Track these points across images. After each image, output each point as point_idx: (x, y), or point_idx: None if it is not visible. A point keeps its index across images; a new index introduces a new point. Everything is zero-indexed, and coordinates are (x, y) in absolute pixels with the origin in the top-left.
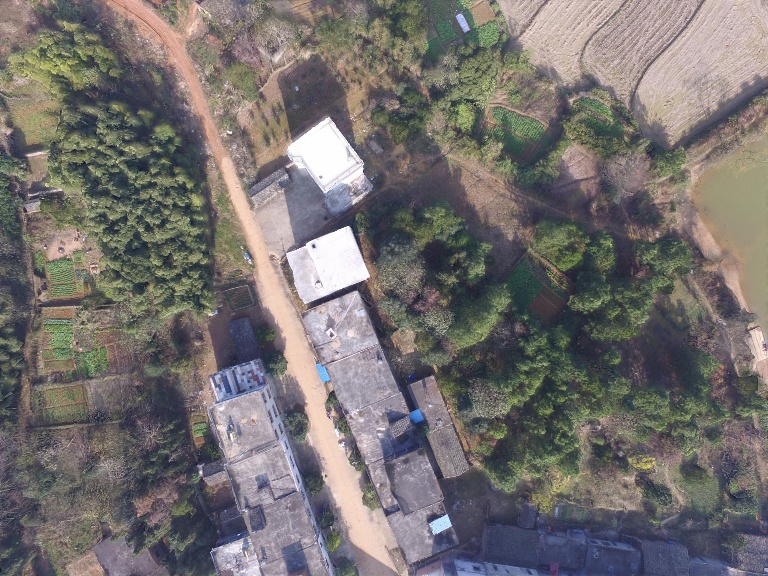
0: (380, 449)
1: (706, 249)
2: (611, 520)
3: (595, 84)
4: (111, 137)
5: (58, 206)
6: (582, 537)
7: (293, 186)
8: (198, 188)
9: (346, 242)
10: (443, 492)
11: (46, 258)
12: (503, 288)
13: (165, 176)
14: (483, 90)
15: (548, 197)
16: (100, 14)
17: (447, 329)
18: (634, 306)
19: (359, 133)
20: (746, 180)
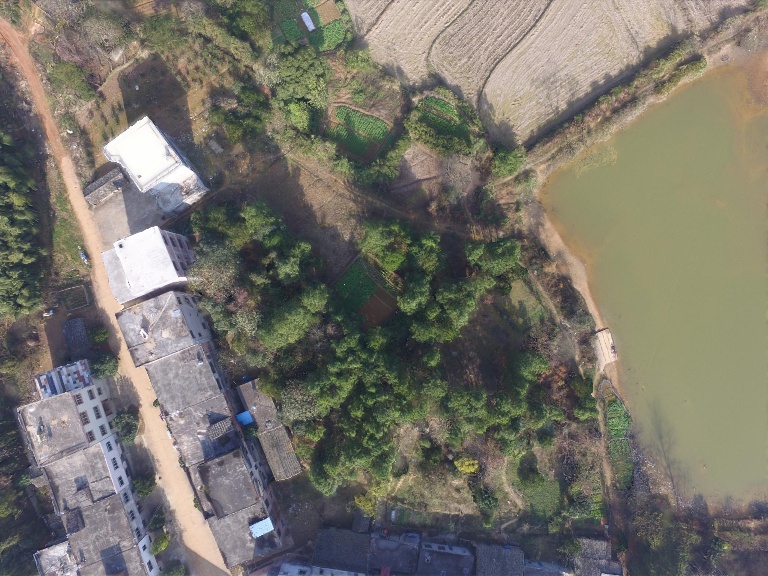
0: (201, 451)
1: (553, 250)
2: (448, 524)
3: (442, 83)
4: None
5: None
6: (415, 541)
7: (131, 186)
8: (21, 187)
9: (154, 242)
10: (278, 495)
11: None
12: (321, 289)
13: None
14: (310, 89)
15: (387, 197)
16: None
17: (256, 330)
18: (454, 307)
19: (198, 132)
20: (590, 180)
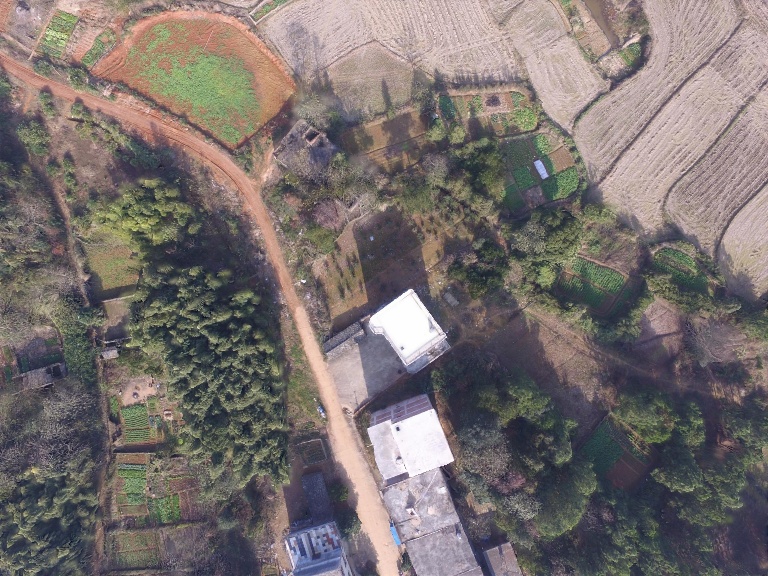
0: None
1: None
2: None
3: (678, 233)
4: (192, 302)
5: (134, 355)
6: None
7: (367, 338)
8: (277, 353)
9: (431, 425)
10: None
11: (121, 403)
12: (588, 468)
13: (245, 342)
14: (568, 256)
15: (629, 355)
16: (176, 160)
17: None
18: (726, 490)
19: (434, 285)
20: None
